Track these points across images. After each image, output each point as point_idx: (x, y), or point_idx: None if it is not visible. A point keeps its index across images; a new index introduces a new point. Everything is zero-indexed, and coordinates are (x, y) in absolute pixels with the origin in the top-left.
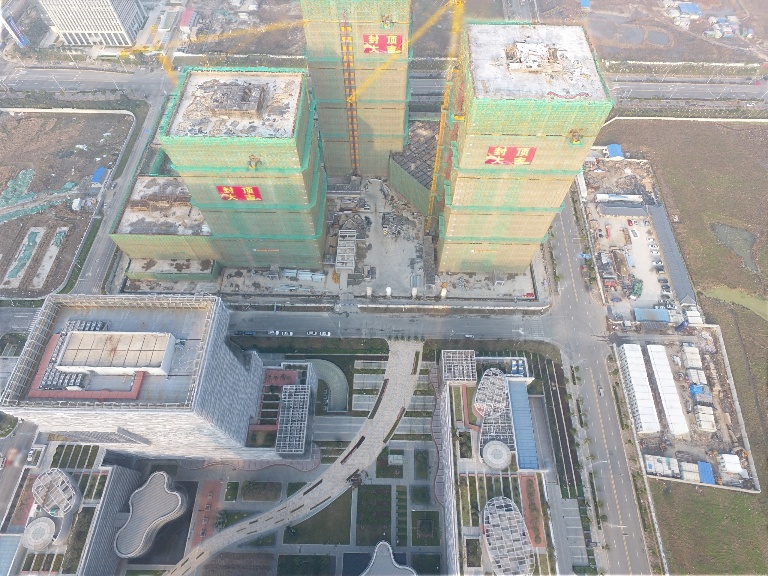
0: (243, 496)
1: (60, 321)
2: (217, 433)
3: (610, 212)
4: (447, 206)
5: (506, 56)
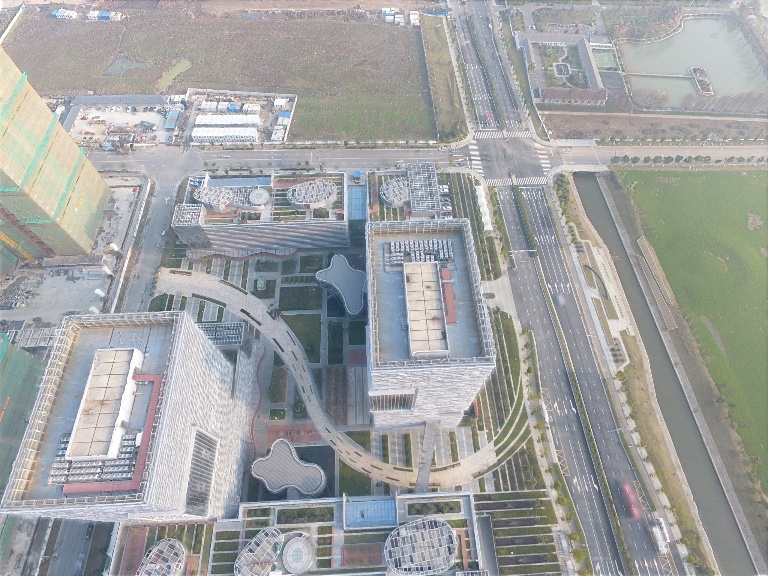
0: (282, 401)
1: (44, 498)
2: (212, 348)
3: (68, 127)
4: (19, 190)
5: None
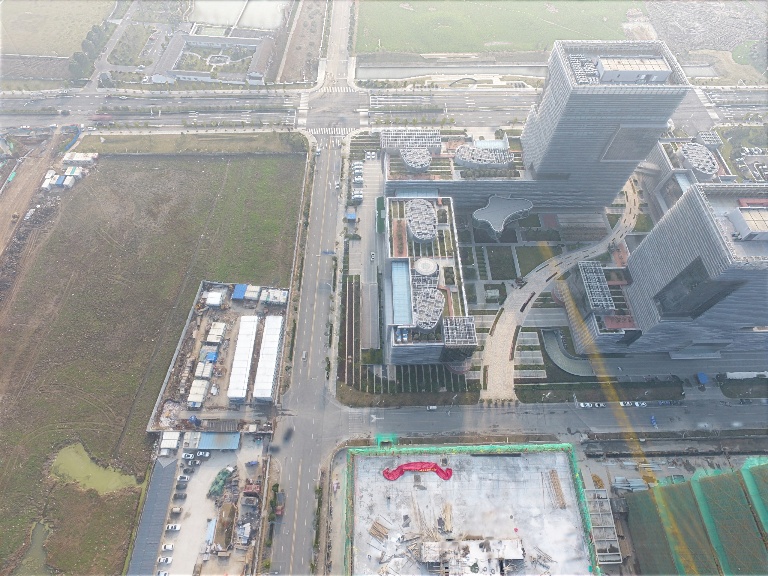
0: None
1: None
2: None
3: None
4: None
5: None
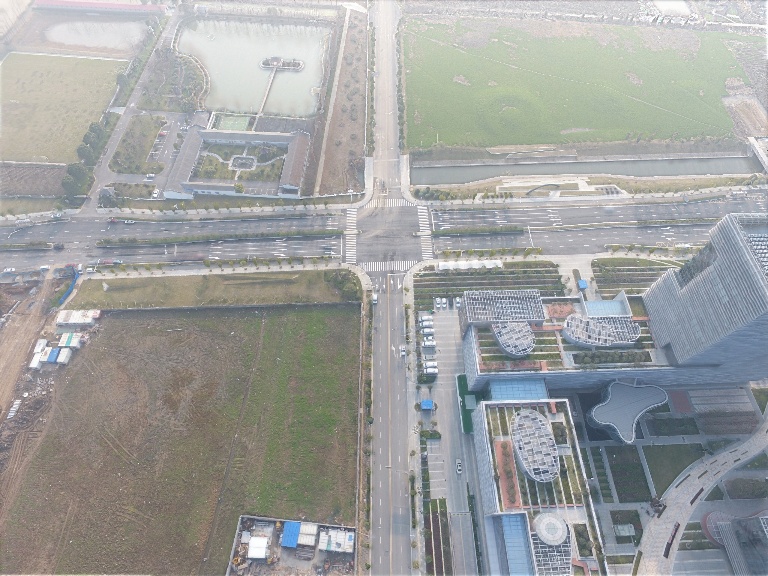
0: None
1: None
2: None
3: None
4: None
5: None
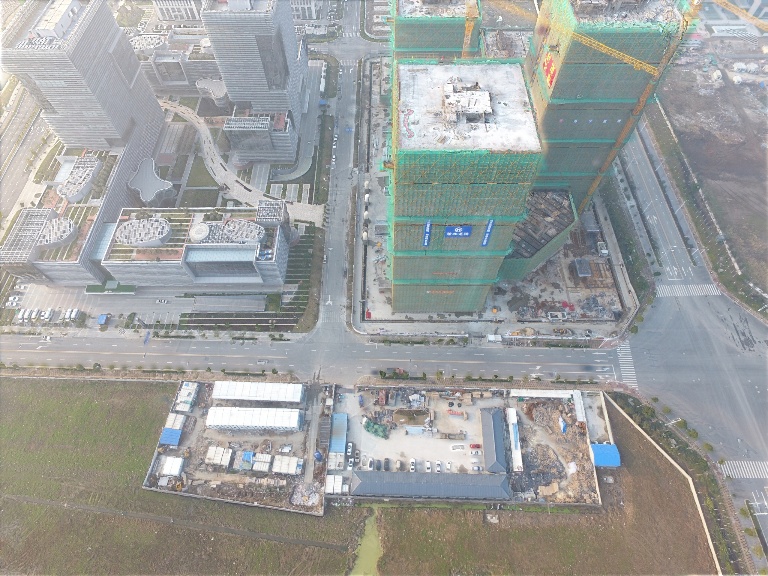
0: None
1: None
2: None
3: (485, 417)
4: None
5: (468, 87)
